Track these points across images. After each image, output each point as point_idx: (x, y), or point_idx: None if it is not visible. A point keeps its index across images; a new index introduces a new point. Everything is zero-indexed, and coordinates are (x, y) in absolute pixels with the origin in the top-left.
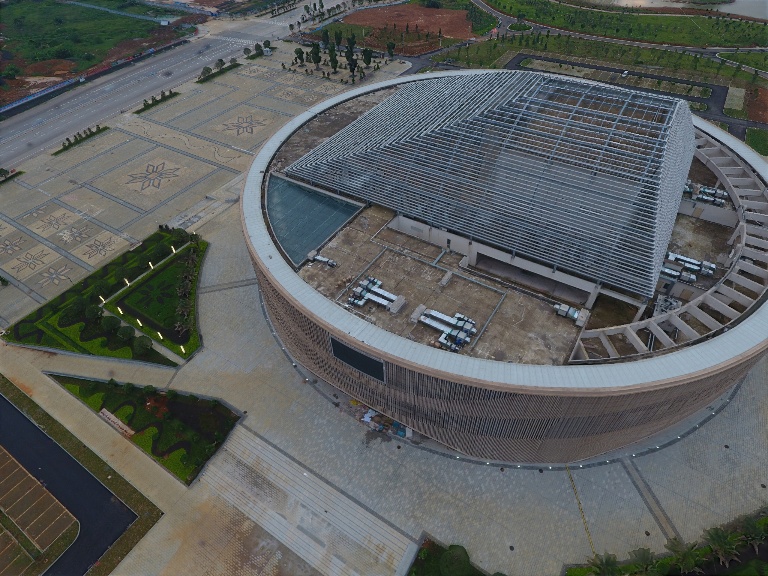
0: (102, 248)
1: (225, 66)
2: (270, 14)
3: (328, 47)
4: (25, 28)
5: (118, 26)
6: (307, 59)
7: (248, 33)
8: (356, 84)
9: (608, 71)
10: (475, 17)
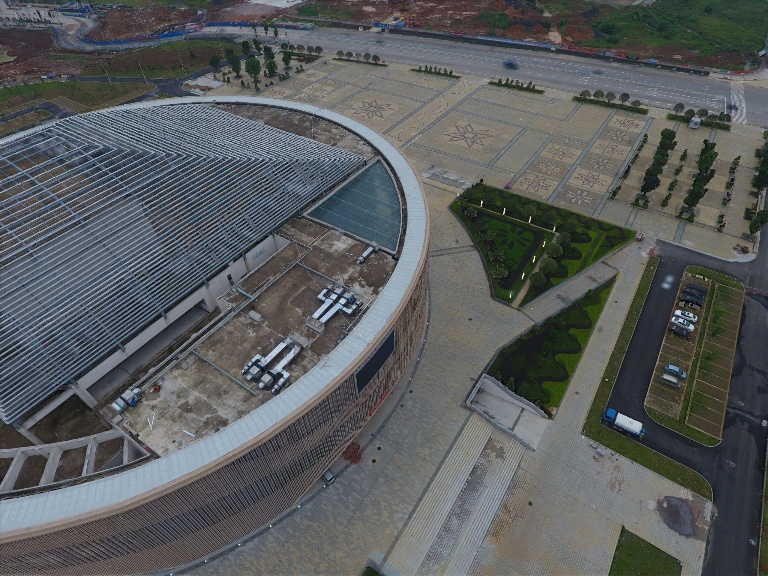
0: None
1: None
2: None
3: None
4: (680, 5)
5: (726, 35)
6: None
7: None
8: (611, 201)
9: None
10: None
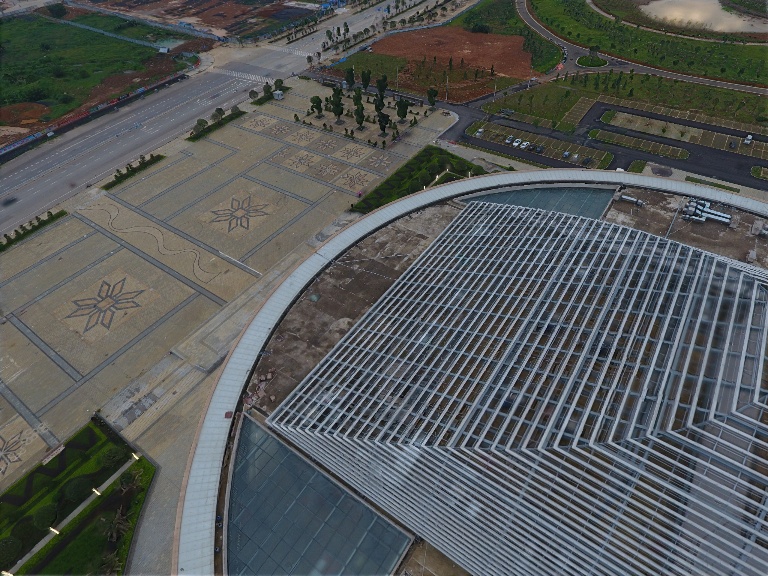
0: (4, 455)
1: (225, 114)
2: (286, 39)
3: (353, 88)
4: (7, 55)
5: (111, 54)
6: (326, 107)
7: (258, 66)
8: (387, 148)
9: (723, 133)
10: (534, 47)
